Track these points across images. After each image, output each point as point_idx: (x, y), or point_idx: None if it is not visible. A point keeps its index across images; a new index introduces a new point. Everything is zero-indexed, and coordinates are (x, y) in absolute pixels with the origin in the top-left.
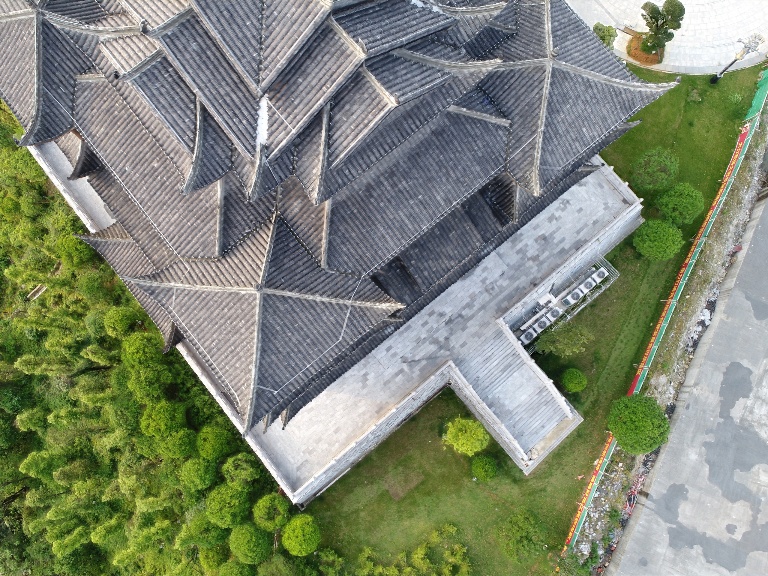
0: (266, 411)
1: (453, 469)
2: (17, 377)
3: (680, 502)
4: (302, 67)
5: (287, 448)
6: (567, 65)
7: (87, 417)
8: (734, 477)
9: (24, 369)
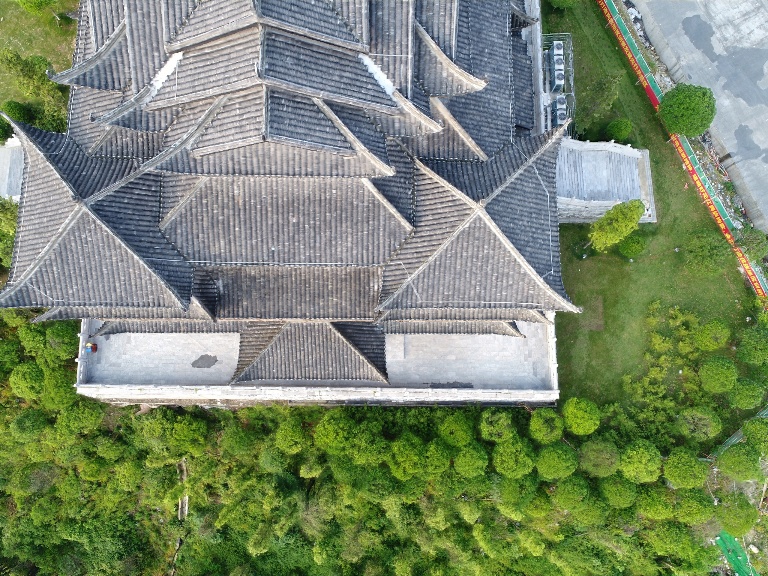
0: (561, 290)
1: (612, 270)
2: (247, 574)
3: (751, 137)
4: (372, 2)
5: (512, 370)
6: None
7: (331, 537)
8: (761, 88)
9: (261, 550)
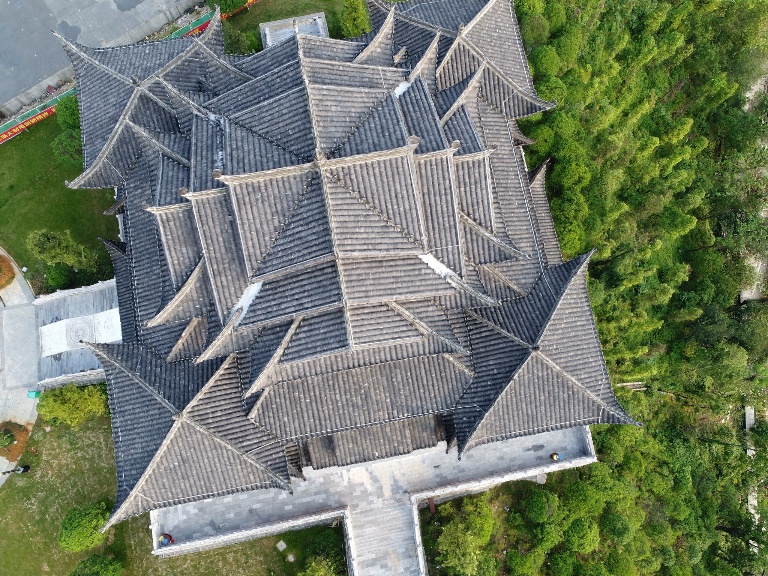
0: None
1: None
2: None
3: None
4: None
5: None
6: (130, 79)
7: None
8: None
9: None
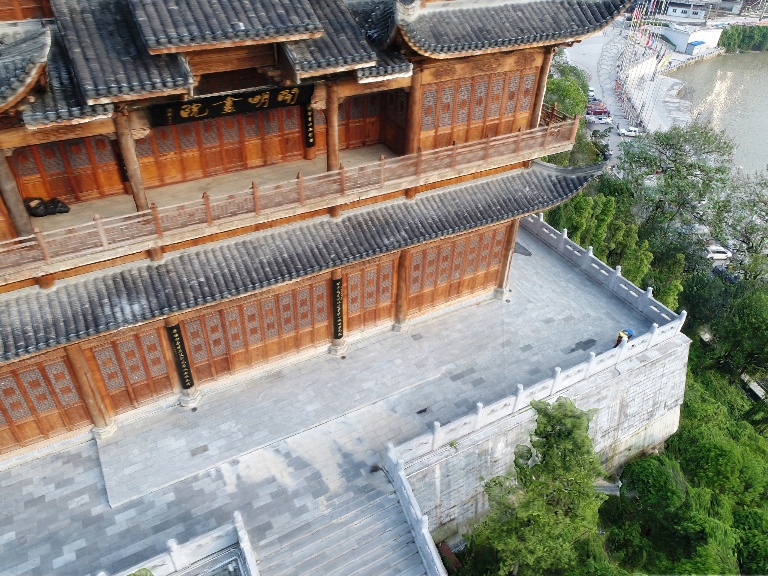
0: None
1: None
2: None
3: None
4: None
5: None
6: None
7: None
8: None
9: None
